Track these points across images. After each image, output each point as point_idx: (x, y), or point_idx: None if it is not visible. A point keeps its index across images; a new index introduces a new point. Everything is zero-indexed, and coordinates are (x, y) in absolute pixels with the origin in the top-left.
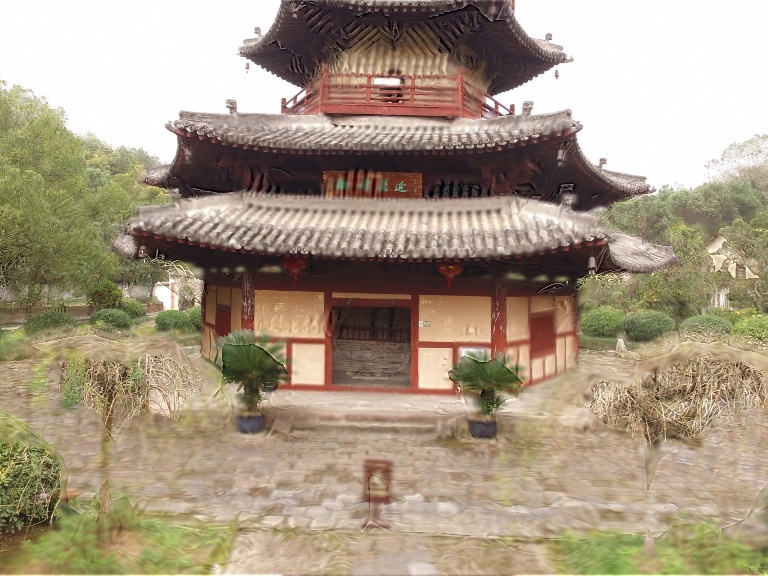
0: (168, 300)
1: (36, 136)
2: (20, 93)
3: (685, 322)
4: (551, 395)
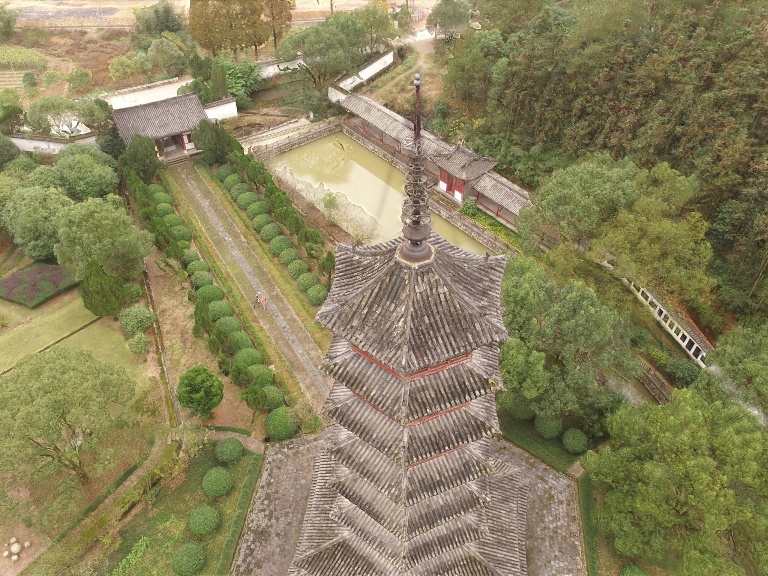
0: None
1: None
2: None
3: None
4: None
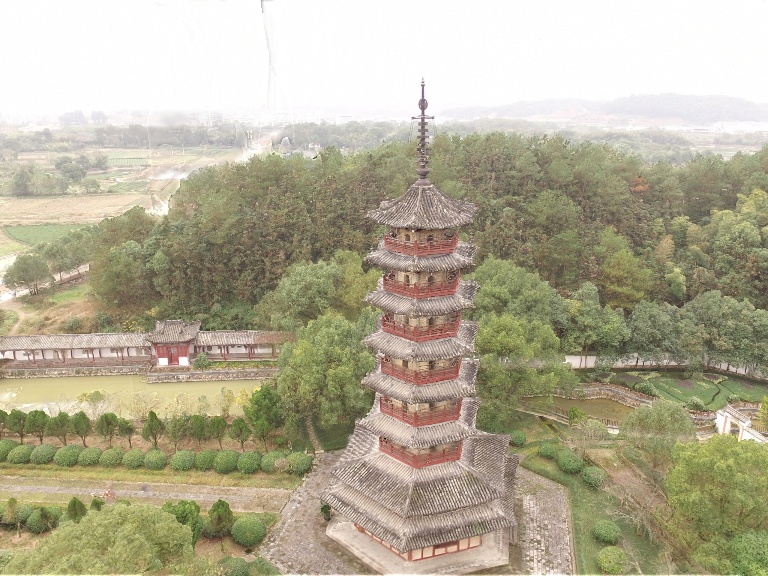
0: None
1: None
2: None
3: None
4: (359, 538)
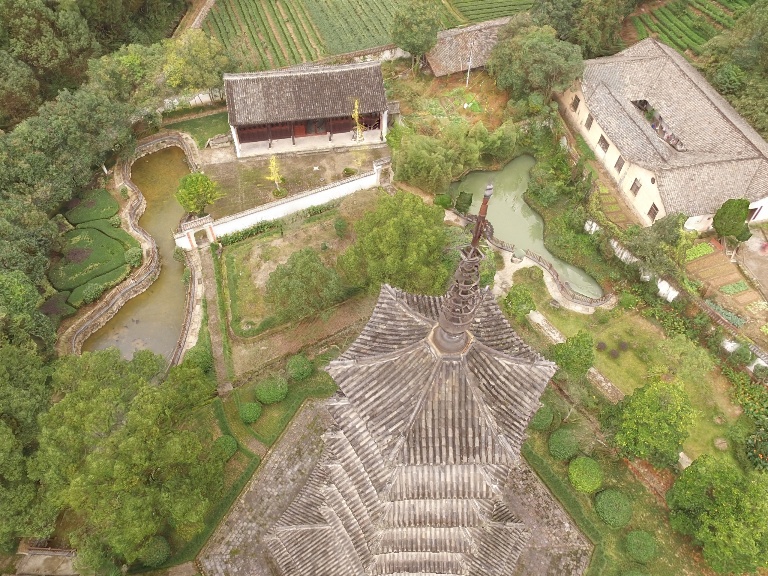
0: (188, 244)
1: (175, 458)
2: (144, 424)
3: (553, 442)
4: None
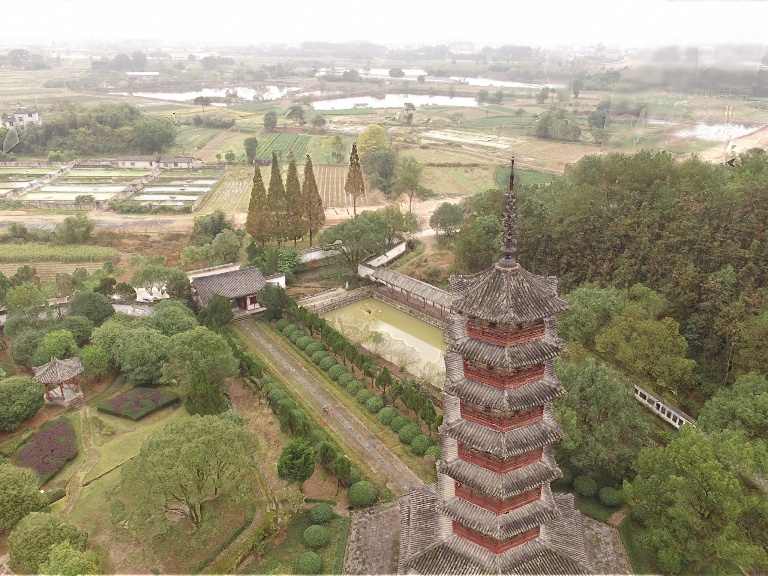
0: None
1: None
2: None
3: None
4: None
